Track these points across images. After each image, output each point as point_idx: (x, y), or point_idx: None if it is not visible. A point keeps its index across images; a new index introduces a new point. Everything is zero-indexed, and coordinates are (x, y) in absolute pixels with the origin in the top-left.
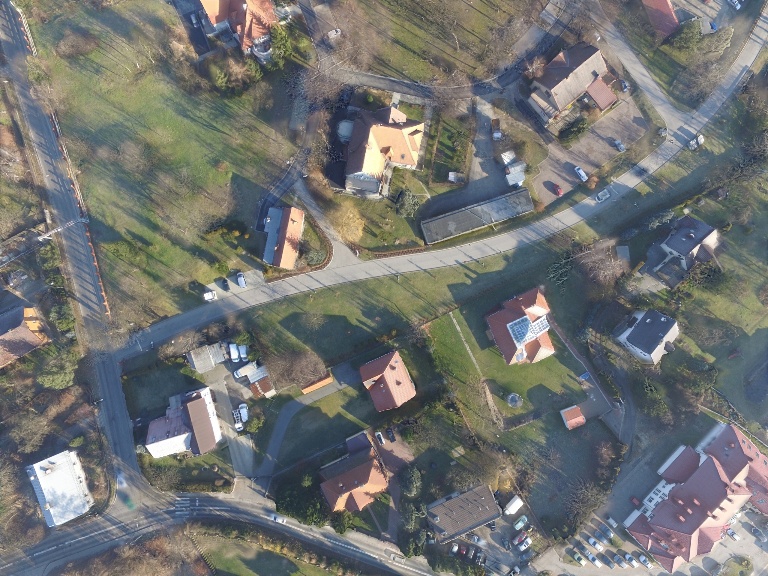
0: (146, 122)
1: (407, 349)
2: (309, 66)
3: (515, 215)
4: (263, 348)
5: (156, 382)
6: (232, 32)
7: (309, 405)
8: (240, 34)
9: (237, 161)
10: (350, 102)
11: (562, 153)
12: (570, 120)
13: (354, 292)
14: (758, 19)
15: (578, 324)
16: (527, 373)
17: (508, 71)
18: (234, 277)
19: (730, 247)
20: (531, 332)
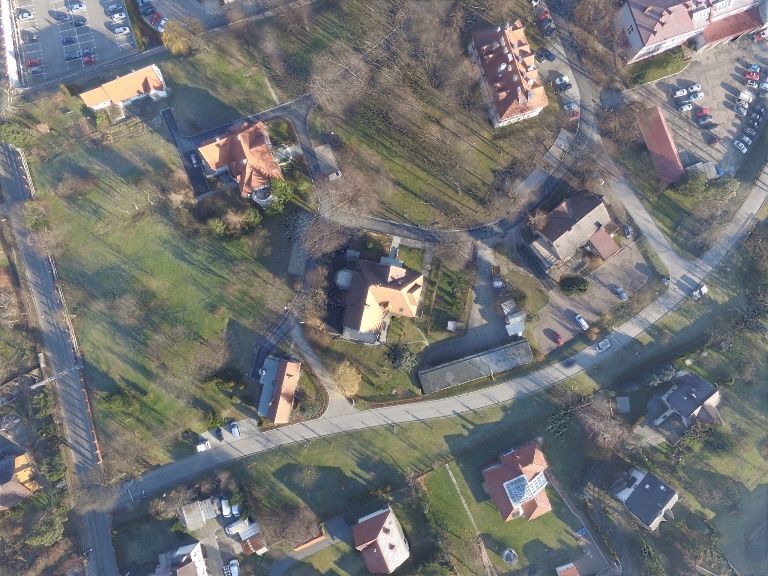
0: (143, 265)
1: (402, 503)
2: (309, 208)
3: (514, 367)
4: (255, 502)
5: (146, 535)
6: (232, 176)
7: (301, 560)
8: (240, 183)
9: (234, 306)
10: (349, 246)
11: (563, 300)
12: (572, 266)
13: (349, 443)
14: (764, 166)
15: (576, 478)
16: (523, 527)
17: (510, 215)
18: (228, 426)
19: (732, 400)
20: (528, 494)
